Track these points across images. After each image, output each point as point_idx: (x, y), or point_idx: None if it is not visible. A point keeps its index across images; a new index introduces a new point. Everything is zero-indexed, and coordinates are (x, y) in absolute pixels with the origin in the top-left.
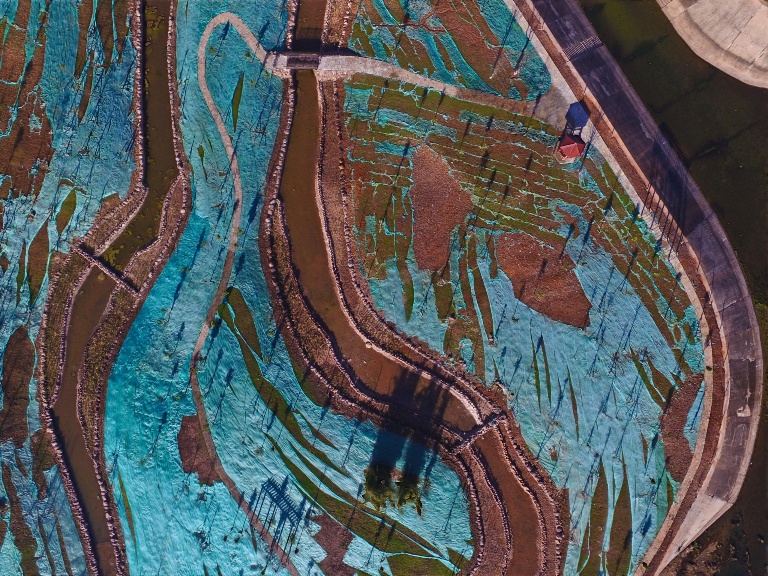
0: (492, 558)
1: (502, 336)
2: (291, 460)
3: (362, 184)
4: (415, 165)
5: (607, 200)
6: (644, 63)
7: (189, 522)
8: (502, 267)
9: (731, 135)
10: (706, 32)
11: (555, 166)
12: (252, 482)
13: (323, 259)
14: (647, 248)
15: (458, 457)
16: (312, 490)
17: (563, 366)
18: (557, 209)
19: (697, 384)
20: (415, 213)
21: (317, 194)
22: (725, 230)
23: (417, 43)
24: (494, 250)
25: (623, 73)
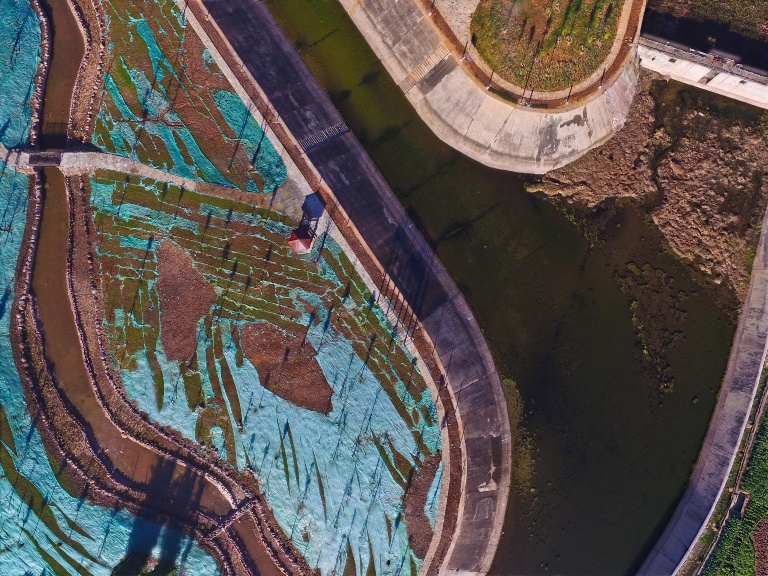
0: None
1: (250, 423)
2: (48, 552)
3: (110, 278)
4: (159, 258)
5: (345, 288)
6: (390, 148)
7: None
8: (247, 356)
9: (475, 216)
10: (444, 118)
11: (294, 256)
12: (10, 575)
13: (77, 352)
14: (384, 334)
15: (214, 542)
16: None
17: (309, 451)
18: (298, 298)
19: (435, 464)
20: (161, 305)
21: (68, 288)
22: (472, 309)
23: (156, 138)
24: (239, 340)
25: (370, 158)
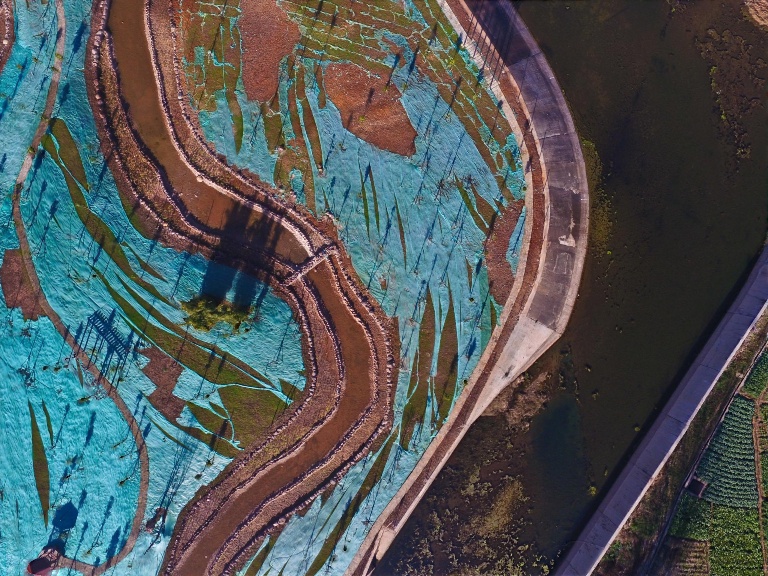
0: (325, 389)
1: (331, 166)
2: (118, 293)
3: (190, 15)
4: None
5: (431, 30)
6: None
7: (13, 358)
8: (330, 97)
9: None
10: None
11: None
12: (78, 316)
13: (153, 93)
14: (470, 77)
15: (290, 289)
16: (140, 322)
17: (390, 194)
18: (383, 39)
19: (518, 209)
20: (243, 43)
21: (146, 26)
22: (553, 69)
23: None
24: (322, 80)
25: None
